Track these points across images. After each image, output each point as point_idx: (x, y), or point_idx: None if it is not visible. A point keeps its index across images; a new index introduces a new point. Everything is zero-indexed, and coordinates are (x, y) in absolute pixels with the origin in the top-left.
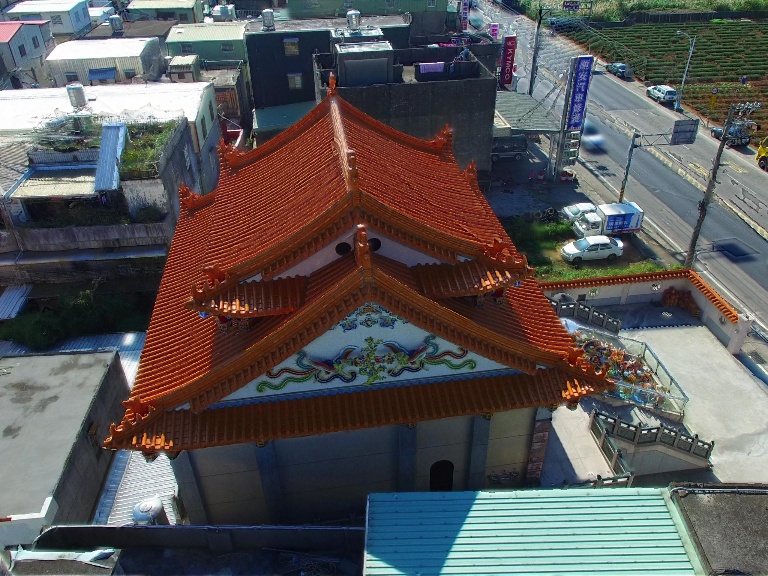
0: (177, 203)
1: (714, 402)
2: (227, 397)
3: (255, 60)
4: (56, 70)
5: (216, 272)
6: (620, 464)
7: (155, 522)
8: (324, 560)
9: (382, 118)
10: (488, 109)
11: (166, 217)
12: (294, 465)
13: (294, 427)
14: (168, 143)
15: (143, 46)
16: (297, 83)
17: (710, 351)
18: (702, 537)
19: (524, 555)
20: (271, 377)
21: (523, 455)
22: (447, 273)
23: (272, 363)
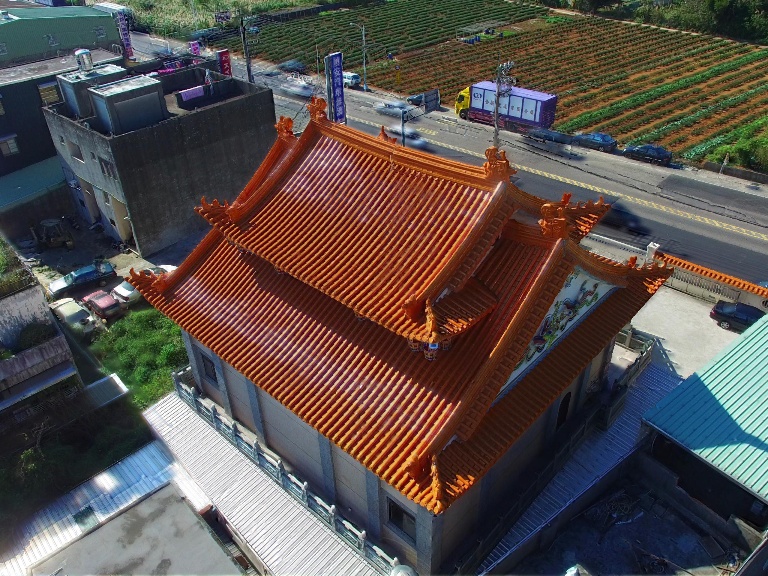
0: None
1: None
2: None
3: None
4: None
5: (415, 303)
6: (637, 340)
7: None
8: (617, 496)
9: (178, 154)
10: (270, 120)
11: (57, 328)
12: None
13: (536, 408)
14: None
15: None
16: (11, 147)
17: None
18: None
19: (765, 390)
20: None
21: (601, 362)
22: None
23: (519, 356)
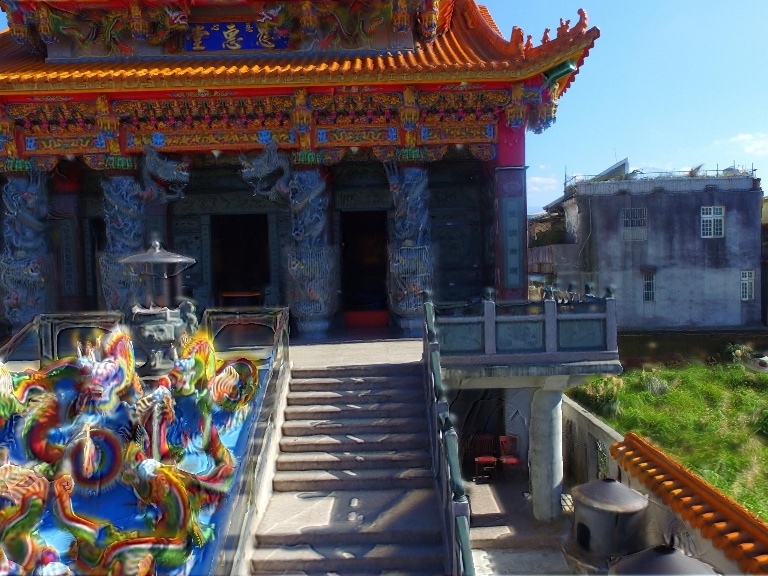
0: (616, 248)
1: None
2: None
3: None
4: None
5: None
6: None
7: None
8: None
9: None
10: None
11: (567, 244)
12: None
13: None
14: (647, 179)
15: None
16: None
17: None
18: None
19: None
20: None
21: None
22: None
23: None
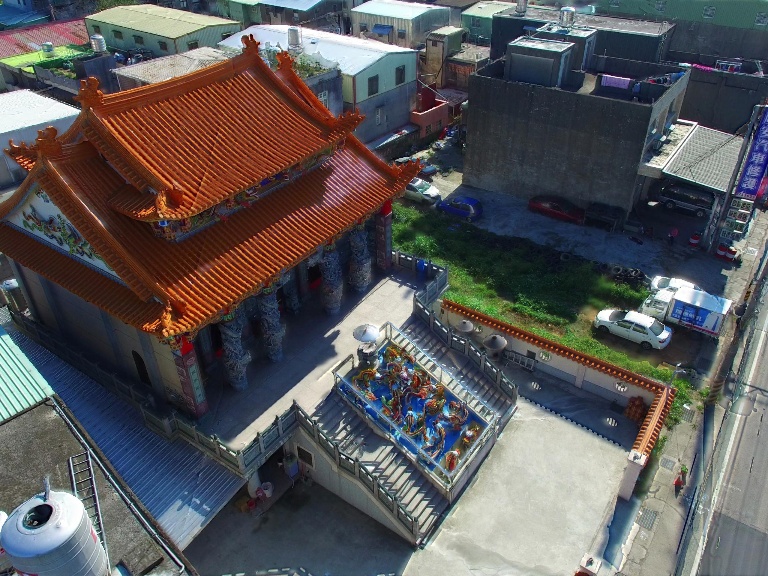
0: None
1: (517, 512)
2: (15, 222)
3: (497, 42)
4: (355, 20)
5: None
6: None
7: (11, 294)
8: None
9: (522, 118)
10: (637, 140)
11: None
12: (62, 298)
13: (21, 256)
14: None
15: (423, 12)
16: None
17: (597, 476)
18: (6, 425)
19: None
20: (26, 218)
21: None
22: (137, 197)
23: None
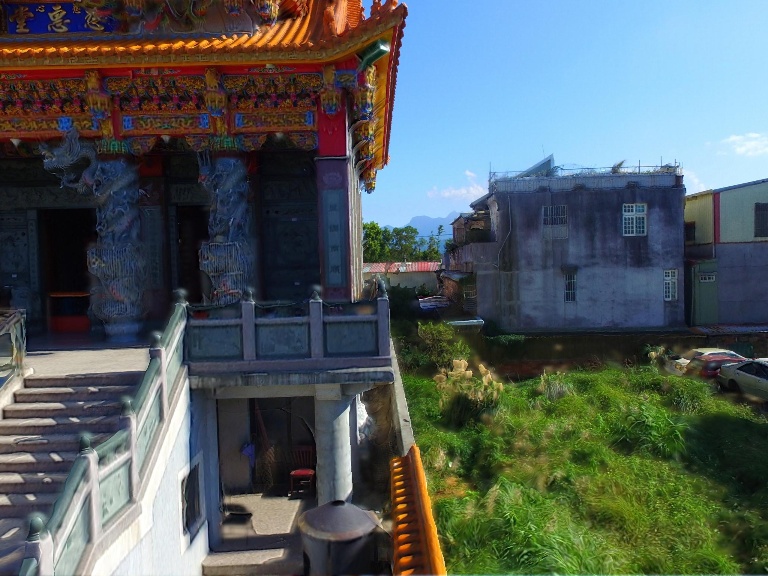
0: (537, 247)
1: None
2: None
3: None
4: None
5: None
6: None
7: None
8: None
9: None
10: None
11: (486, 242)
12: None
13: None
14: (568, 176)
15: None
16: None
17: None
18: None
19: None
20: None
21: None
22: None
23: None
